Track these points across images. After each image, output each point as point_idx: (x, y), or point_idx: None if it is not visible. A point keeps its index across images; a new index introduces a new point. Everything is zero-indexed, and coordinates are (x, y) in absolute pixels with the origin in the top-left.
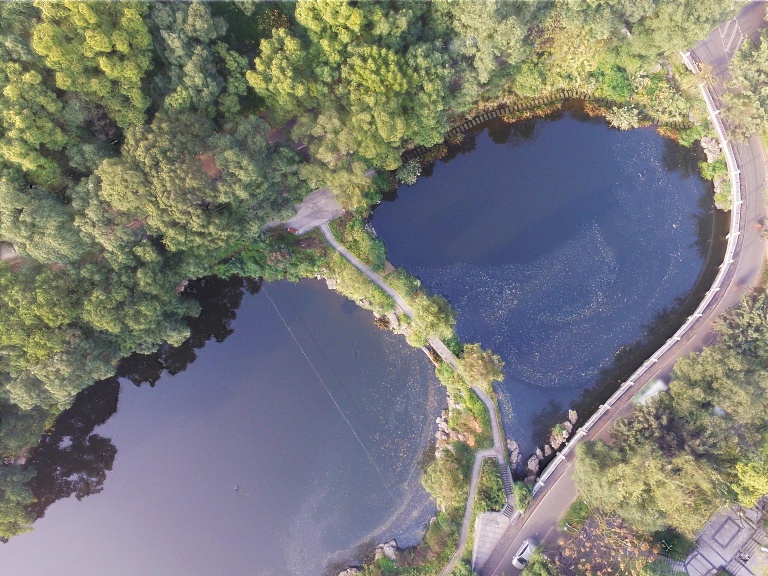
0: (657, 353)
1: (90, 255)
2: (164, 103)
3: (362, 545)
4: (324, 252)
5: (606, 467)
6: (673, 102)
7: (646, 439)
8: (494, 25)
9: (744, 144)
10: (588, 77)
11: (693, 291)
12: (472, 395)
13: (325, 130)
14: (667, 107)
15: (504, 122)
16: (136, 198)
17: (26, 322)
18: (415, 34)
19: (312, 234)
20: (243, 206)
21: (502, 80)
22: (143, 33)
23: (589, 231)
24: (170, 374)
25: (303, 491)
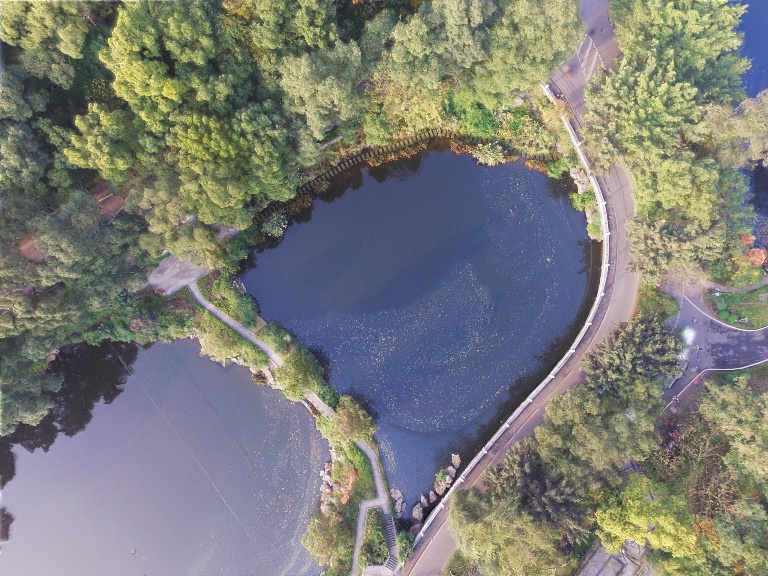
0: (533, 392)
1: None
2: None
3: None
4: (193, 312)
5: (474, 519)
6: (539, 135)
7: (510, 489)
8: (313, 86)
9: (611, 173)
10: (450, 116)
11: (574, 323)
12: (351, 447)
13: (152, 203)
14: (533, 140)
15: None
16: None
17: None
18: (245, 95)
19: (180, 294)
20: (80, 283)
21: (348, 131)
22: None
23: (462, 271)
24: (68, 436)
25: (189, 555)
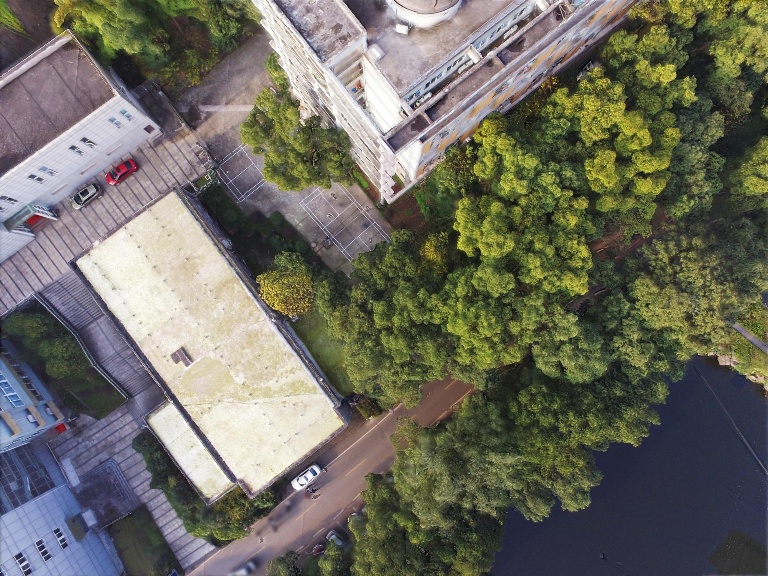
0: None
1: None
2: (666, 212)
3: None
4: None
5: None
6: None
7: None
8: None
9: None
10: None
11: None
12: None
13: None
14: None
15: None
16: None
17: (571, 444)
18: None
19: None
20: None
21: None
22: (672, 149)
23: None
24: None
25: (705, 564)
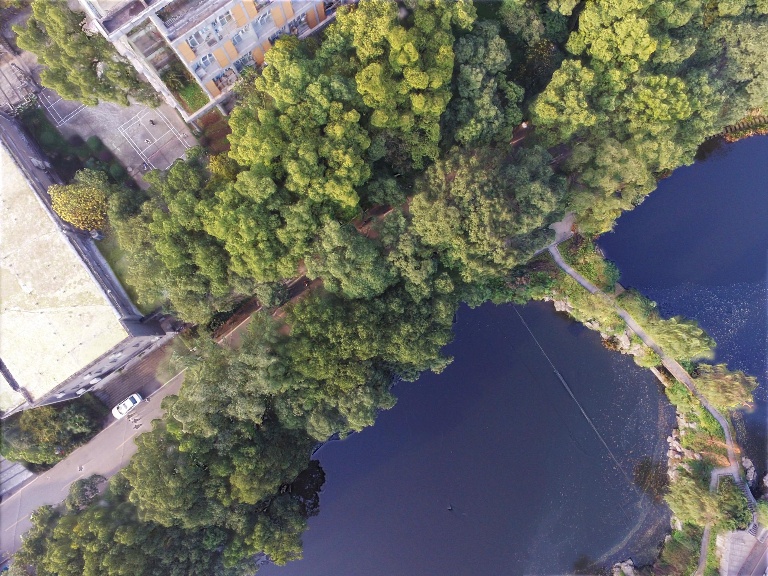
0: None
1: (390, 288)
2: (455, 136)
3: (599, 564)
4: (555, 275)
5: None
6: None
7: None
8: None
9: None
10: None
11: None
12: (707, 414)
13: (613, 159)
14: None
15: (725, 141)
16: (450, 233)
17: (344, 357)
18: (686, 61)
19: (542, 257)
20: (522, 235)
21: None
22: (450, 69)
23: None
24: None
25: (538, 512)
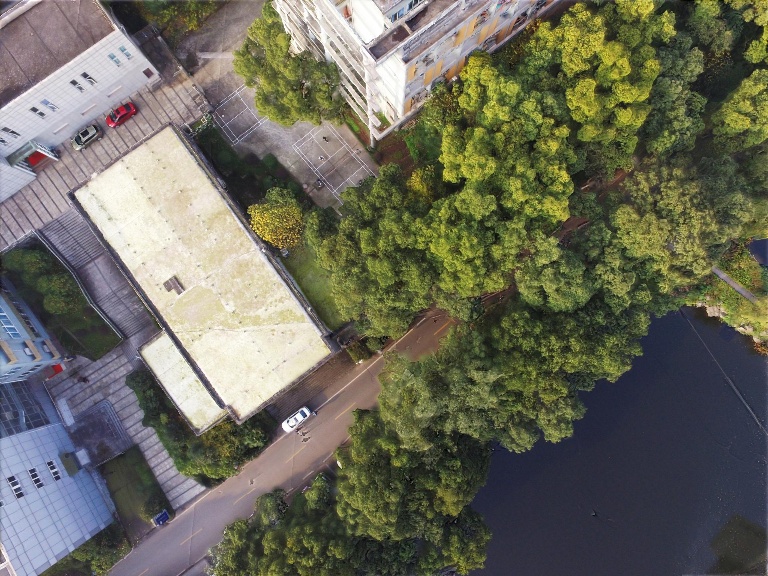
0: None
1: (589, 301)
2: (648, 148)
3: (760, 568)
4: (710, 281)
5: None
6: None
7: None
8: None
9: None
10: None
11: None
12: None
13: None
14: None
15: None
16: None
17: (554, 370)
18: None
19: None
20: None
21: None
22: (652, 82)
23: None
24: None
25: (696, 517)
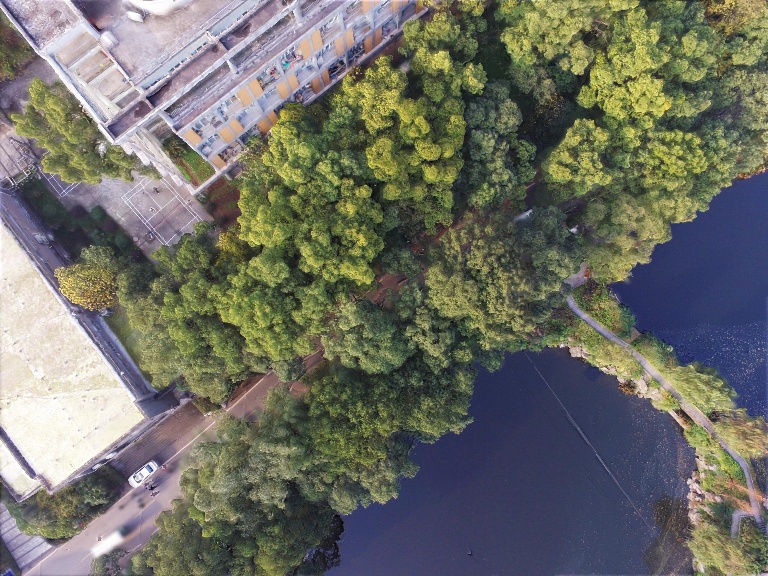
0: None
1: (408, 360)
2: (468, 201)
3: None
4: (570, 322)
5: None
6: None
7: None
8: None
9: None
10: None
11: None
12: (727, 457)
13: (630, 218)
14: None
15: (737, 178)
16: (468, 305)
17: (365, 435)
18: None
19: None
20: None
21: None
22: (461, 136)
23: None
24: None
25: (560, 559)
